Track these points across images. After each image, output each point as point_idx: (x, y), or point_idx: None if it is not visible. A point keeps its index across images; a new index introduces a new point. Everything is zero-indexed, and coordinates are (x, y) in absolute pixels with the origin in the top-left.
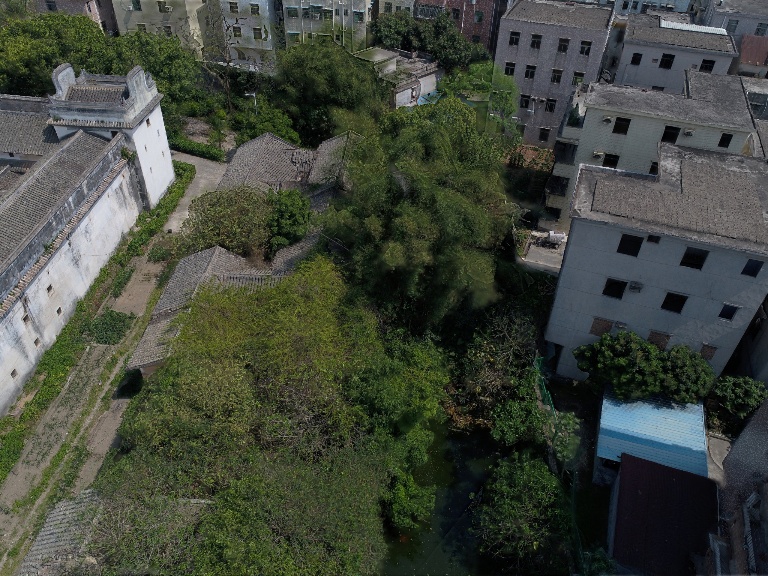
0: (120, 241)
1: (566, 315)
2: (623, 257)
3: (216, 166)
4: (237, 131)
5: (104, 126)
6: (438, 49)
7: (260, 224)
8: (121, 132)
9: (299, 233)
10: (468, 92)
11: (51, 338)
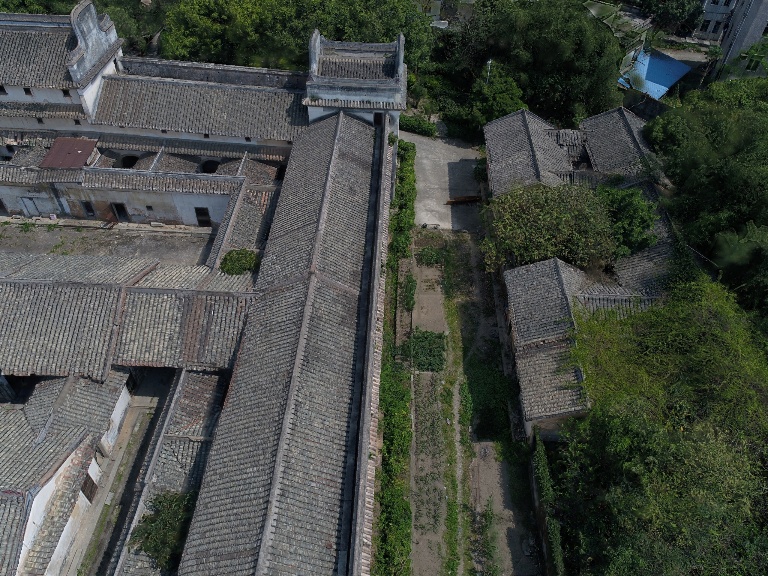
0: None
1: None
2: None
3: (431, 143)
4: (432, 99)
5: (371, 107)
6: (654, 2)
7: (604, 232)
8: (387, 114)
9: (652, 243)
10: (659, 49)
11: None
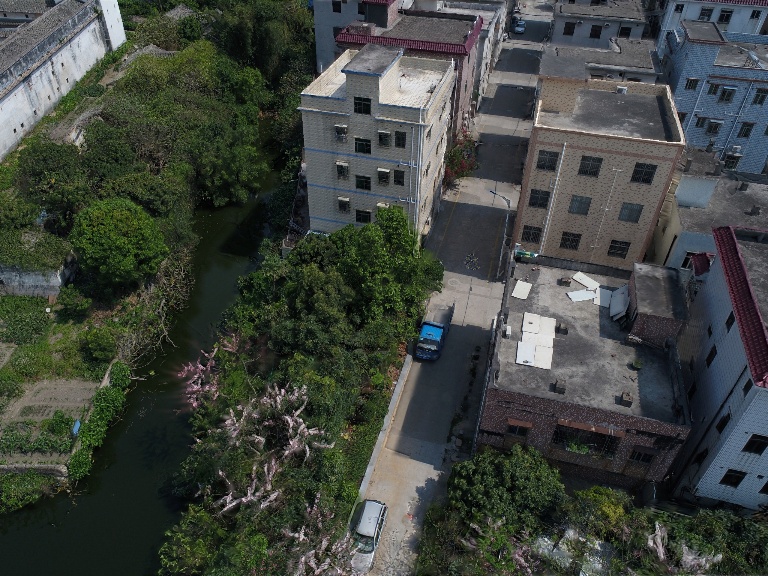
0: (96, 62)
1: (322, 54)
2: (336, 14)
3: None
4: None
5: None
6: None
7: (174, 32)
8: None
9: (195, 35)
10: None
11: (64, 93)
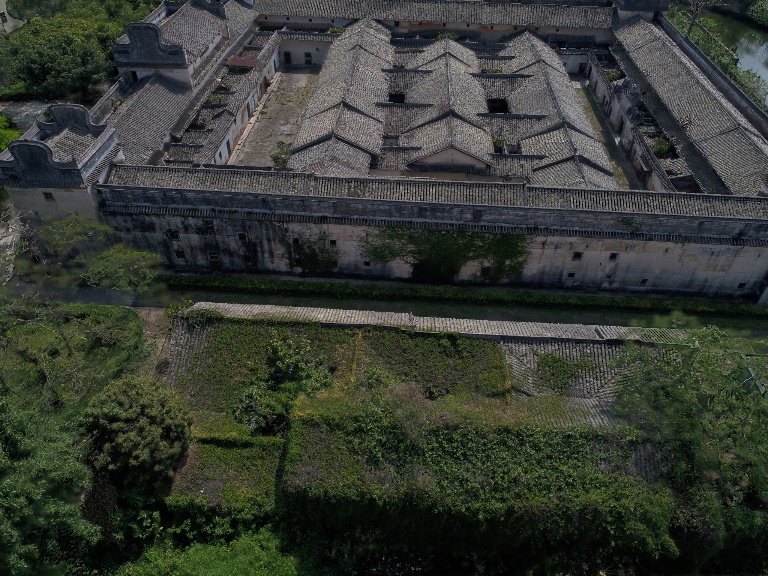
0: None
1: None
2: None
3: None
4: None
5: None
6: None
7: None
8: None
9: None
10: None
11: None
